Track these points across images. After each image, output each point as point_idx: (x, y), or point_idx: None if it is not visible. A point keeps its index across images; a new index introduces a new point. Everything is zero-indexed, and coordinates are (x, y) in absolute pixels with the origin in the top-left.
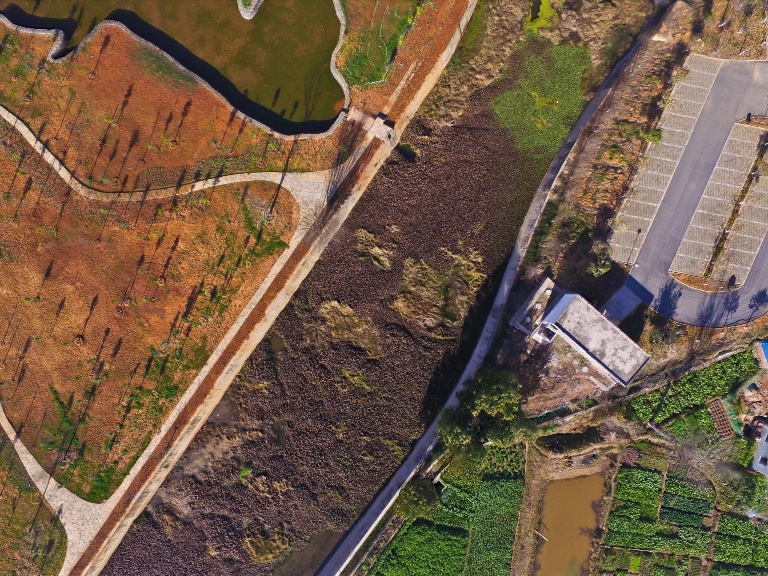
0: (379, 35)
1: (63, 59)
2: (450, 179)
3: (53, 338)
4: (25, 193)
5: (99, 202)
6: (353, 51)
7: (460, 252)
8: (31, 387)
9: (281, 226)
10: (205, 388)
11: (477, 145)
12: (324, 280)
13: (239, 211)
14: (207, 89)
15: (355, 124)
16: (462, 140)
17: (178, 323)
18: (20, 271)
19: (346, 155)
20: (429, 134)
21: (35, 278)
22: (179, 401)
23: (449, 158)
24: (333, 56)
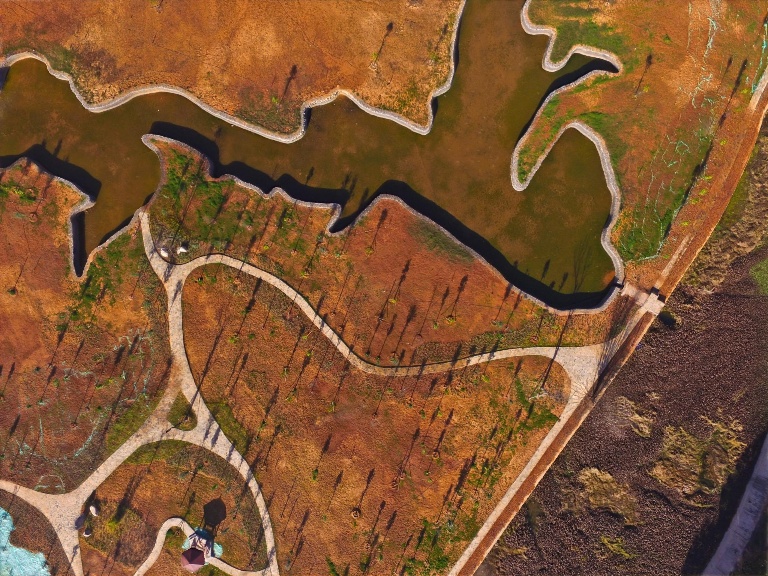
0: (654, 210)
1: (341, 233)
2: (711, 347)
3: (331, 511)
4: (304, 367)
5: (376, 376)
6: (628, 226)
7: (719, 420)
8: (308, 559)
9: (552, 399)
10: (475, 559)
11: (738, 313)
12: (584, 447)
13: (512, 385)
14: (483, 264)
15: (629, 299)
16: (723, 308)
17: (451, 496)
18: (299, 444)
19: (618, 330)
20: (691, 302)
21: (313, 452)
22: (450, 572)
23: (710, 326)
24: (608, 231)
